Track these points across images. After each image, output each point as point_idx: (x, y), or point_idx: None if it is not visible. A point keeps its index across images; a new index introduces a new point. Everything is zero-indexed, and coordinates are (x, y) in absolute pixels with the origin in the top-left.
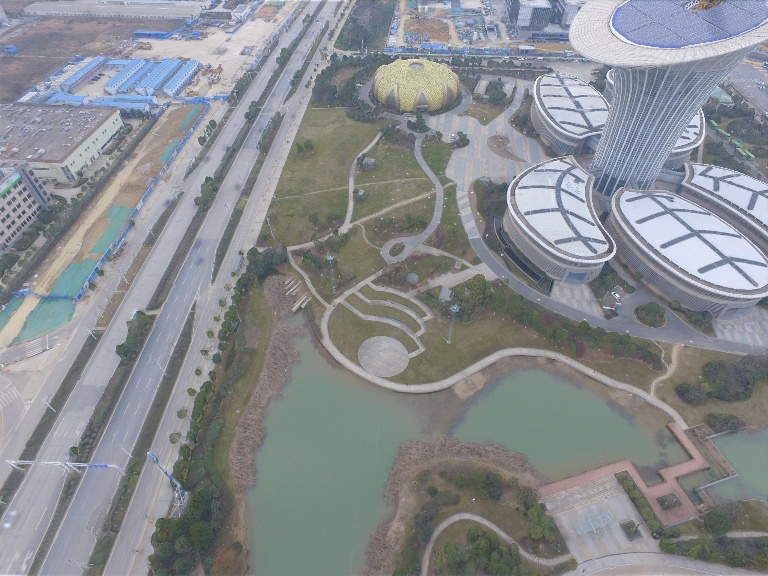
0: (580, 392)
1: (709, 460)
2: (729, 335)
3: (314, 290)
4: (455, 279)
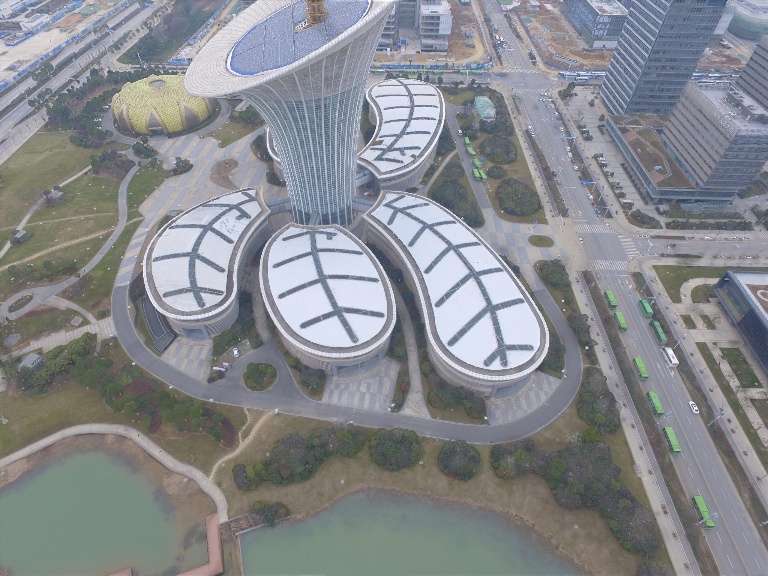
0: (131, 479)
1: (229, 562)
2: (336, 397)
3: None
4: (63, 339)
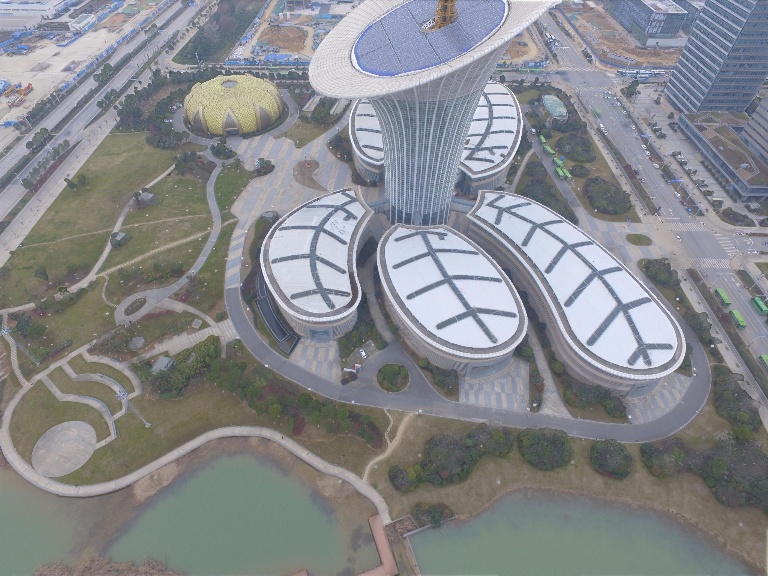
0: (284, 481)
1: (402, 564)
2: (473, 397)
3: (16, 364)
4: (187, 342)
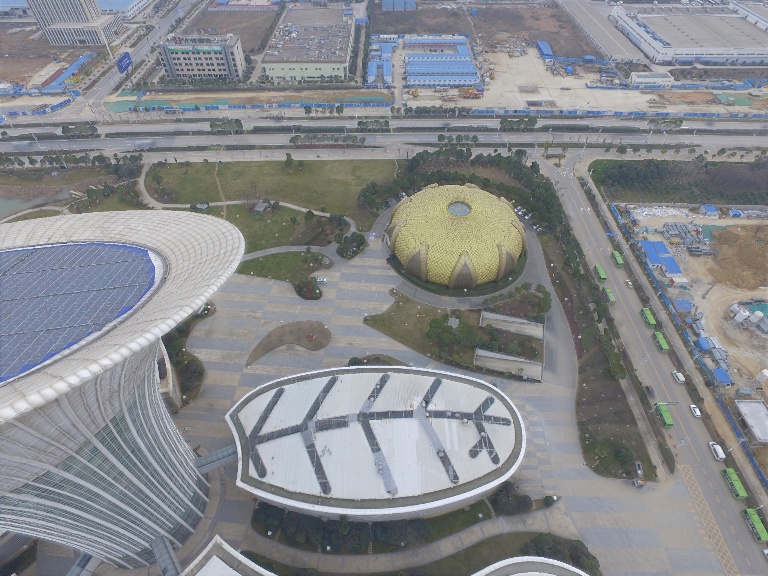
0: None
1: None
2: None
3: (86, 198)
4: None
